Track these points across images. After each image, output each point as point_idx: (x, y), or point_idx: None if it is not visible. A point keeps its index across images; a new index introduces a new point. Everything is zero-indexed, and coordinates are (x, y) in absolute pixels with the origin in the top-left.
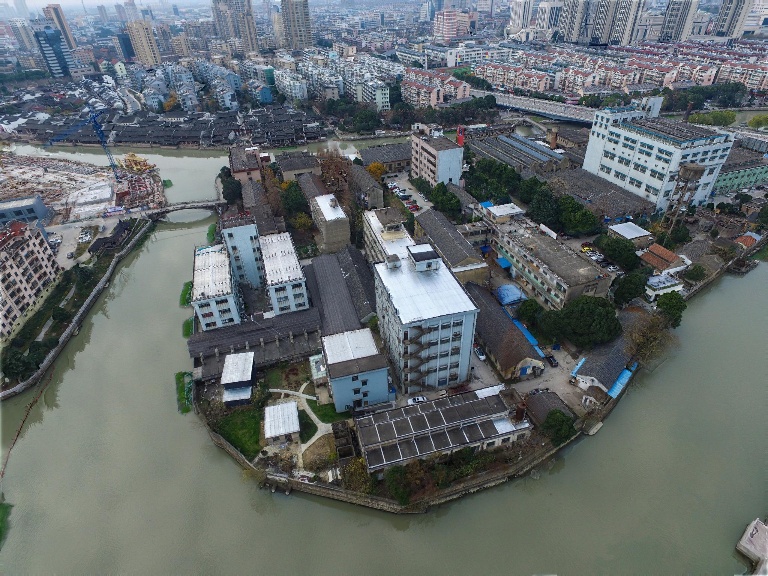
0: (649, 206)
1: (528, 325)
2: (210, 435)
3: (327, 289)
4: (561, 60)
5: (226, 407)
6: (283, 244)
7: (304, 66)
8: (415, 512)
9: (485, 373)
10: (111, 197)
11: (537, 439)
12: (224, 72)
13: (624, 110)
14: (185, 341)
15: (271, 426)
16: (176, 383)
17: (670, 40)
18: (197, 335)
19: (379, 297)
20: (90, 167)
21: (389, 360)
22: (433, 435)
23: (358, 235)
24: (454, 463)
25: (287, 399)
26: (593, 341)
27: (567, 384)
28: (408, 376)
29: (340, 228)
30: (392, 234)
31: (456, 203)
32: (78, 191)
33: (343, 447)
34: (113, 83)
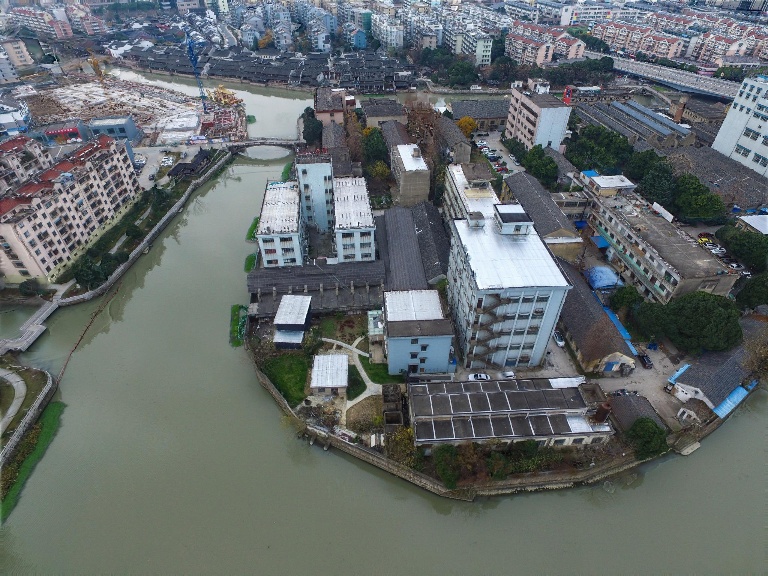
0: None
1: (621, 316)
2: (256, 373)
3: (397, 243)
4: None
5: (276, 348)
6: (357, 189)
7: (404, 12)
8: (460, 498)
9: (562, 361)
10: (197, 126)
11: (616, 447)
12: (321, 13)
13: None
14: (246, 275)
15: (318, 376)
16: (231, 315)
17: None
18: (258, 270)
19: (454, 257)
20: (182, 96)
21: (454, 328)
22: (493, 419)
23: (437, 191)
24: (513, 454)
25: (339, 351)
26: (703, 346)
27: (661, 391)
28: (473, 349)
29: (419, 181)
30: (477, 192)
31: (553, 169)
32: (168, 117)
33: (391, 412)
34: (215, 18)
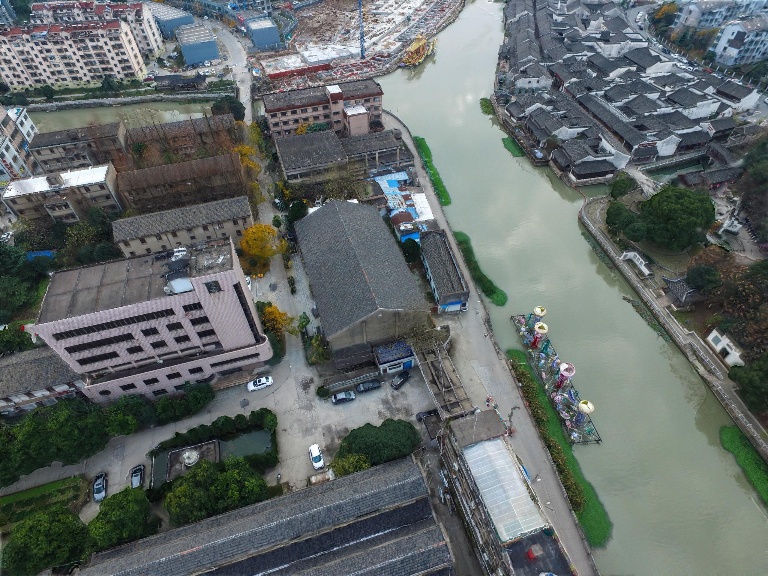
0: None
1: None
2: None
3: None
4: None
5: None
6: None
7: None
8: None
9: None
10: (316, 63)
11: None
12: None
13: None
14: None
15: None
16: None
17: None
18: None
19: None
20: None
21: None
22: None
23: None
24: None
25: None
26: None
27: None
28: None
29: None
30: None
31: None
32: (337, 45)
33: None
34: None
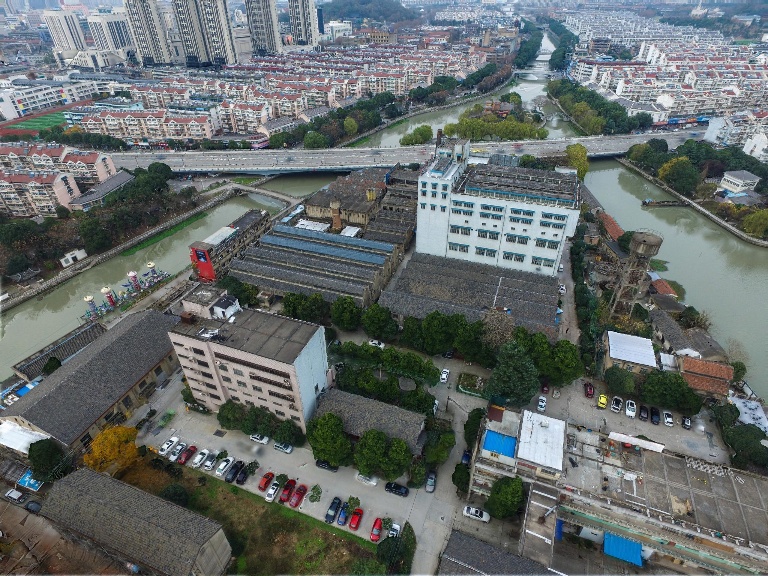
0: (556, 284)
1: None
2: None
3: None
4: (194, 91)
5: None
6: None
7: None
8: None
9: None
10: None
11: None
12: None
13: (447, 167)
14: None
15: None
16: None
17: (276, 53)
18: None
19: None
20: None
21: None
22: None
23: None
24: None
25: None
26: None
27: None
28: None
29: None
30: None
31: (406, 454)
32: None
33: None
34: None
